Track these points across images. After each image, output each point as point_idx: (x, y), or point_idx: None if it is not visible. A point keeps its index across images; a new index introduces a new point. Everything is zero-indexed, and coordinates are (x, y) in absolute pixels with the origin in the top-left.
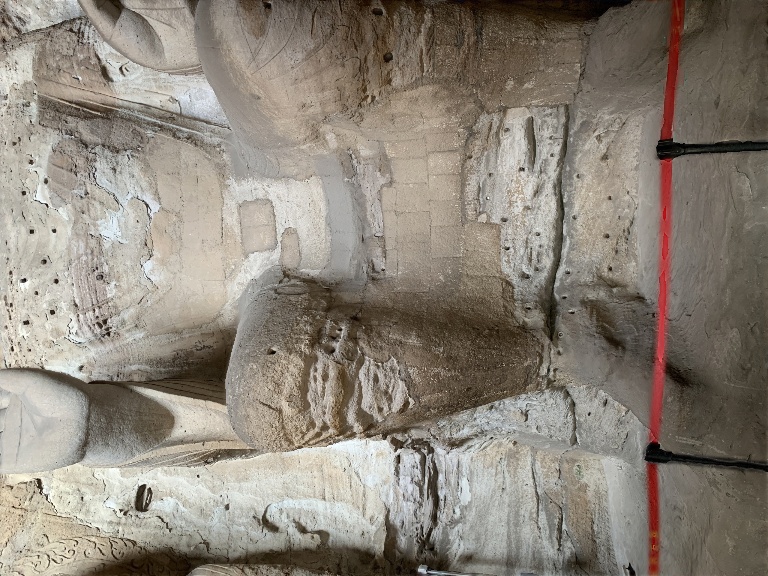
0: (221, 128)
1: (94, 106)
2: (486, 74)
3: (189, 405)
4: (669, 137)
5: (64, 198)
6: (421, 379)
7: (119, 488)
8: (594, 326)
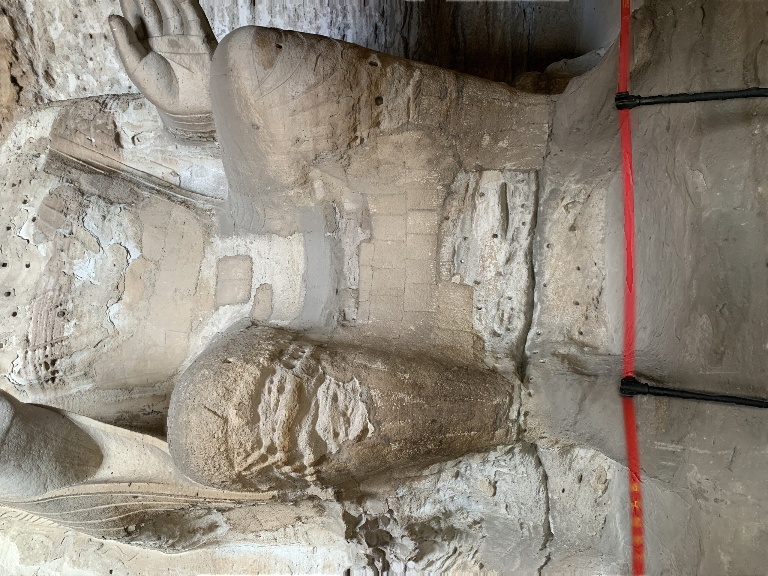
0: (215, 199)
1: (100, 166)
2: (465, 127)
3: (124, 438)
4: (625, 90)
5: (47, 235)
6: (383, 403)
7: None
8: (566, 367)
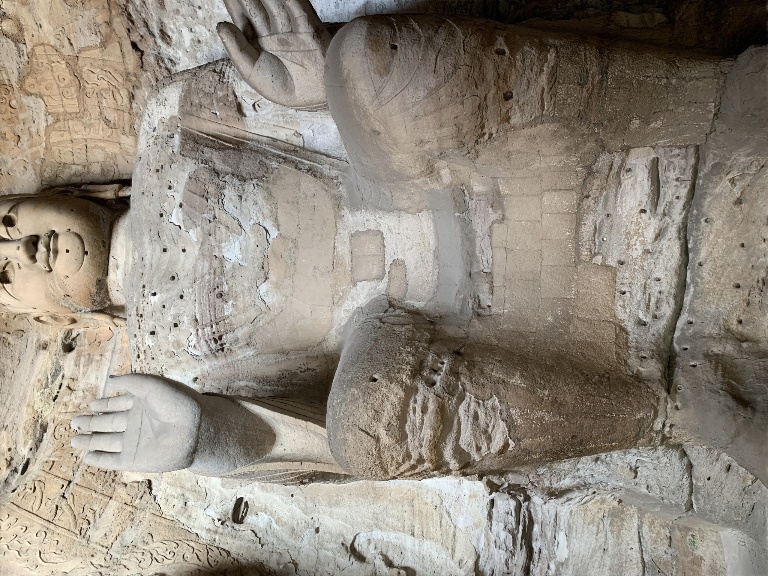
0: (340, 161)
1: (228, 138)
2: (610, 113)
3: (291, 424)
4: None
5: (195, 221)
6: (523, 421)
7: (219, 498)
8: (719, 382)
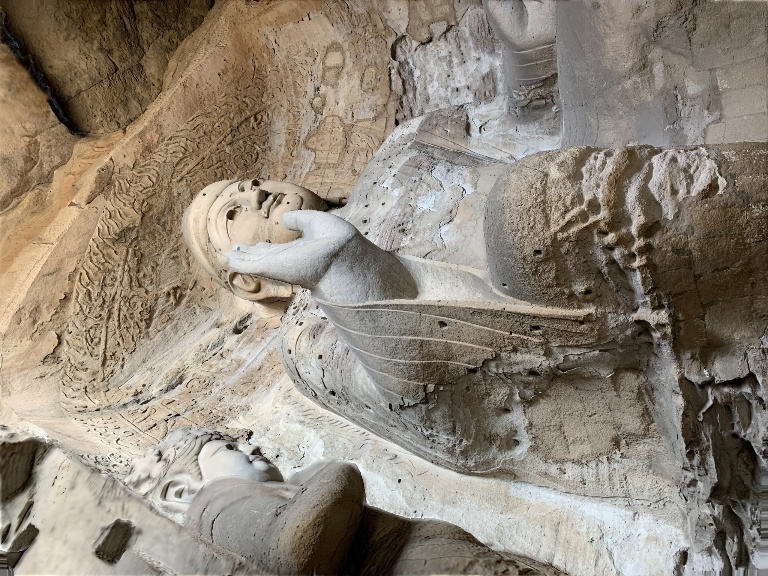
0: None
1: None
2: None
3: (440, 269)
4: None
5: (402, 182)
6: (739, 158)
7: None
8: None
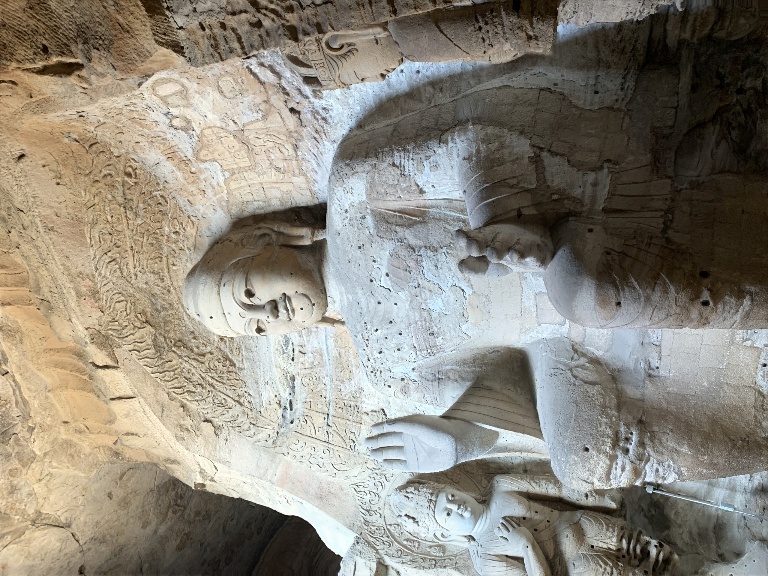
0: None
1: (411, 210)
2: None
3: (512, 434)
4: None
5: (403, 288)
6: (689, 473)
7: None
8: None
